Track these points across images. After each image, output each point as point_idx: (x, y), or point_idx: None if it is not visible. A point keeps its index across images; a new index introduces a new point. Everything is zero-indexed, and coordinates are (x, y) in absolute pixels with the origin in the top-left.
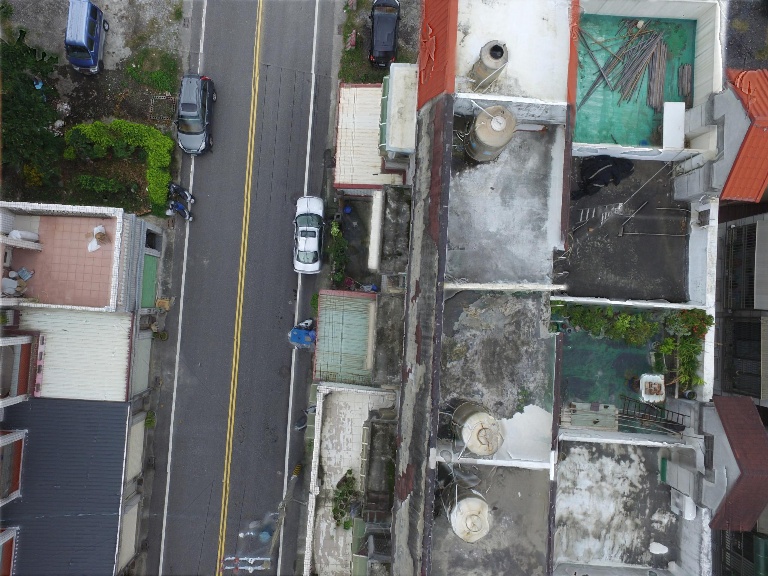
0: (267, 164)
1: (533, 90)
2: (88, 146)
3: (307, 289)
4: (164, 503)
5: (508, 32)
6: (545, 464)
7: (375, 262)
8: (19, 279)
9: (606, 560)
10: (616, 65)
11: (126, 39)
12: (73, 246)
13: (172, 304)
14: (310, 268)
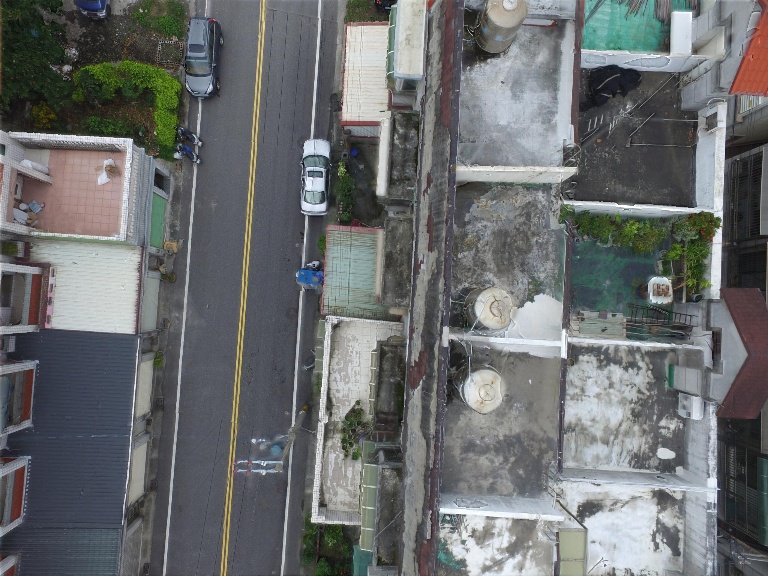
0: (274, 108)
1: None
2: (96, 87)
3: (314, 232)
4: (173, 443)
5: None
6: (556, 342)
7: (383, 189)
8: (30, 212)
9: (614, 465)
10: None
11: None
12: (83, 179)
13: (180, 247)
14: (317, 209)
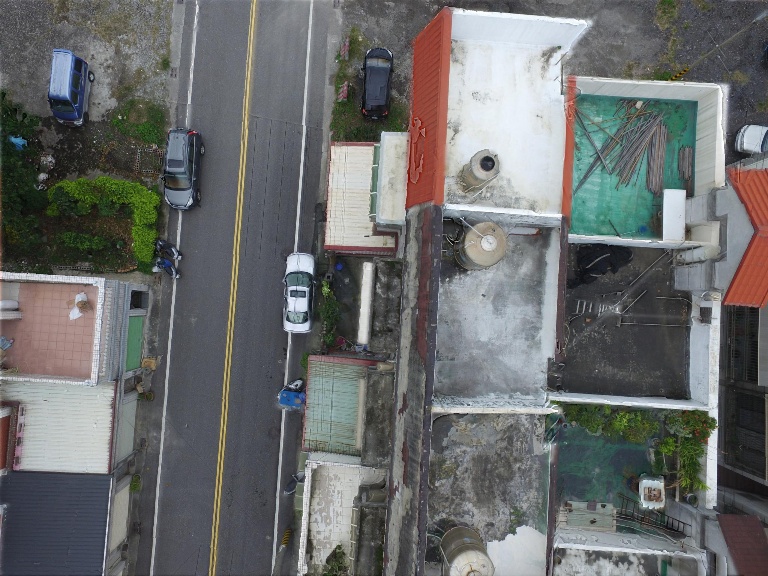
0: (256, 219)
1: (527, 191)
2: (72, 204)
3: (297, 347)
4: (149, 569)
5: (500, 130)
6: None
7: (365, 336)
8: None
9: None
10: (614, 147)
11: (112, 90)
12: (54, 314)
13: (158, 363)
14: (300, 328)
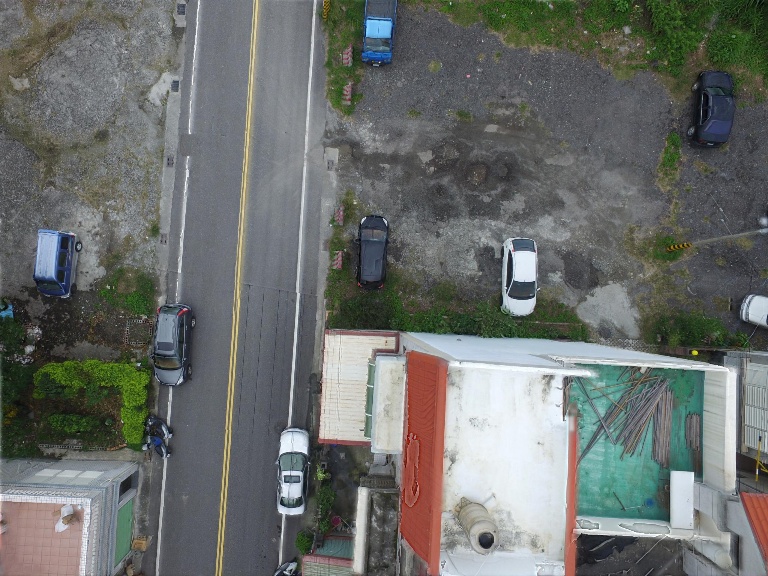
0: (249, 391)
1: (528, 525)
2: (58, 389)
3: (292, 524)
4: None
5: (500, 459)
6: None
7: (361, 566)
8: None
9: None
10: (618, 414)
11: (100, 258)
12: (39, 526)
13: (149, 543)
14: (294, 512)
